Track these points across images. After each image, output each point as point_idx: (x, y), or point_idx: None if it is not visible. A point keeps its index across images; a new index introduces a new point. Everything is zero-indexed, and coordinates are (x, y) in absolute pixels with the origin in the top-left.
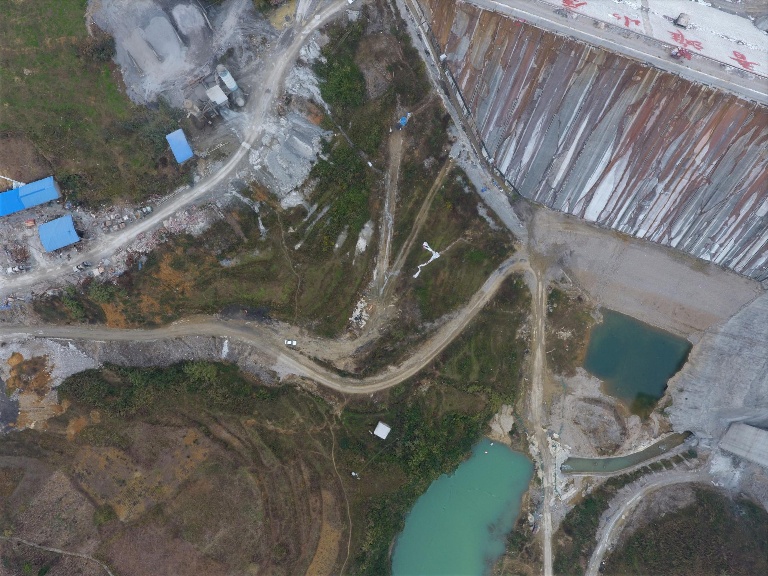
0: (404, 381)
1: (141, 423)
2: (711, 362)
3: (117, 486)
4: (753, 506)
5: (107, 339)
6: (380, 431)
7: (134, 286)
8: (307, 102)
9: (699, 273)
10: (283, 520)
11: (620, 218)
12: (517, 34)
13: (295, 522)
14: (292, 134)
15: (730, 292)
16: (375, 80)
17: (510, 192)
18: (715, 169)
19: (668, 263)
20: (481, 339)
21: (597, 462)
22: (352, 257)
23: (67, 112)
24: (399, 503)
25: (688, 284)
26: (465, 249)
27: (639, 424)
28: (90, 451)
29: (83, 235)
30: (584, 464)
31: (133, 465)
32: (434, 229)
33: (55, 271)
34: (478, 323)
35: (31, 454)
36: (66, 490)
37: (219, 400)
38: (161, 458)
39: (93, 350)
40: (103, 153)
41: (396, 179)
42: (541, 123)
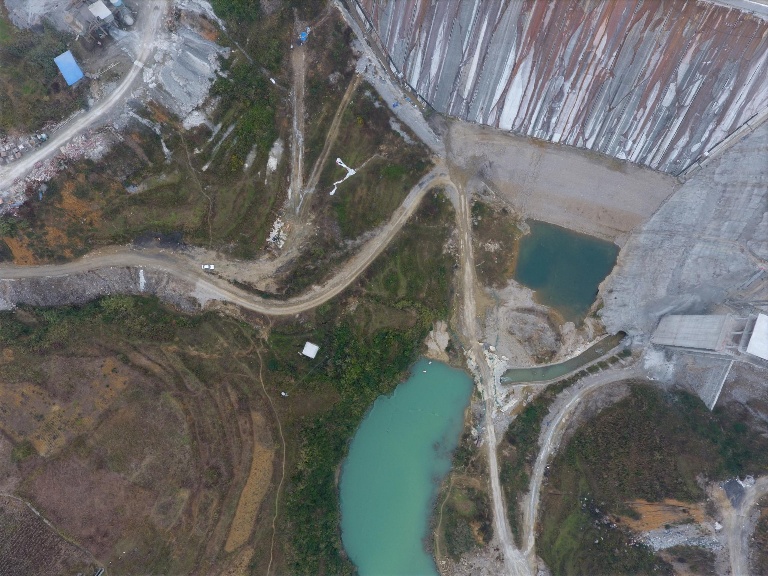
0: (329, 300)
1: (56, 356)
2: (636, 260)
3: (35, 421)
4: (686, 394)
5: (16, 277)
6: (308, 350)
7: (36, 217)
8: (199, 17)
9: (616, 172)
10: (212, 443)
11: (534, 124)
12: None
13: (224, 444)
14: (185, 49)
15: (648, 189)
16: None
17: (424, 108)
18: (616, 61)
19: (585, 165)
20: (407, 255)
21: (536, 371)
22: (264, 176)
23: None
24: (336, 424)
25: (607, 185)
26: (381, 165)
27: (574, 330)
28: (4, 389)
29: None
30: (523, 374)
31: (50, 399)
32: (347, 145)
33: None
34: (402, 238)
35: None
36: None
37: (137, 328)
38: (79, 389)
39: (3, 290)
40: None
41: (302, 95)
42: (443, 30)
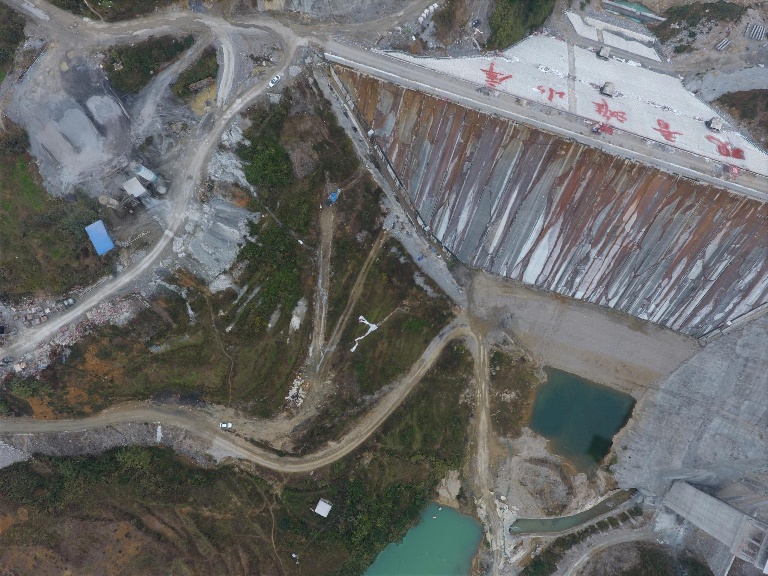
0: (345, 456)
1: (70, 519)
2: (653, 420)
3: None
4: (696, 565)
5: (35, 431)
6: (321, 509)
7: (59, 379)
8: (231, 186)
9: (637, 332)
10: None
11: (557, 281)
12: (441, 111)
13: None
14: (216, 220)
15: (668, 350)
16: (301, 160)
17: (448, 258)
18: (644, 236)
19: (607, 323)
20: (423, 407)
21: (545, 522)
22: (286, 336)
23: None
24: None
25: (628, 343)
26: (403, 319)
27: (586, 482)
28: (17, 551)
29: (4, 330)
30: (533, 525)
31: (63, 563)
32: (370, 302)
33: None
34: (419, 392)
35: None
36: None
37: (152, 489)
38: (92, 554)
39: (21, 443)
40: (21, 246)
41: (328, 255)
42: (472, 194)
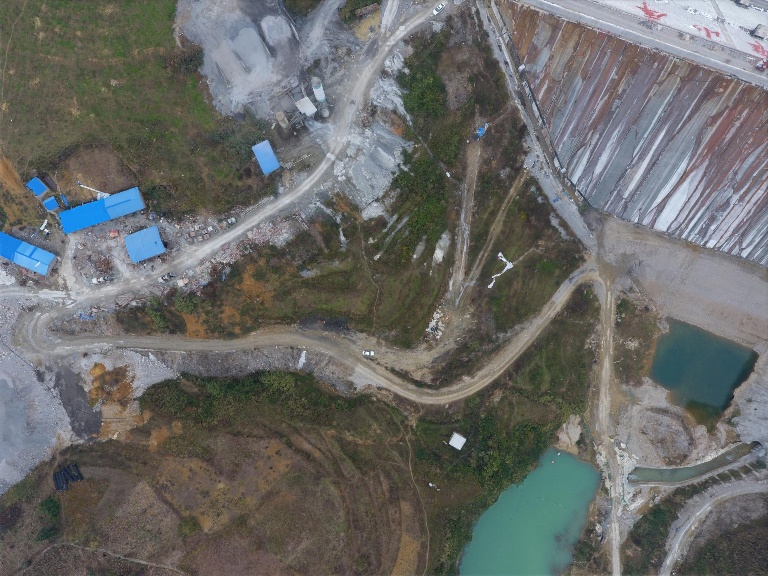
0: (478, 391)
1: (223, 434)
2: None
3: (201, 497)
4: None
5: (187, 349)
6: (455, 442)
7: (217, 297)
8: (391, 113)
9: None
10: (364, 531)
11: (691, 228)
12: (600, 45)
13: (376, 533)
14: (377, 145)
15: None
16: (456, 91)
17: (580, 202)
18: None
19: (738, 273)
20: (552, 349)
21: (664, 472)
22: (429, 268)
23: (153, 123)
24: (472, 513)
25: (757, 294)
26: (538, 259)
27: (706, 434)
28: (173, 462)
29: (167, 246)
30: (651, 474)
31: (216, 476)
32: (508, 239)
33: (139, 282)
34: (549, 333)
35: (115, 465)
36: (151, 501)
37: (299, 411)
38: (244, 469)
39: (172, 360)
40: (188, 164)
41: (473, 189)
42: (617, 134)
